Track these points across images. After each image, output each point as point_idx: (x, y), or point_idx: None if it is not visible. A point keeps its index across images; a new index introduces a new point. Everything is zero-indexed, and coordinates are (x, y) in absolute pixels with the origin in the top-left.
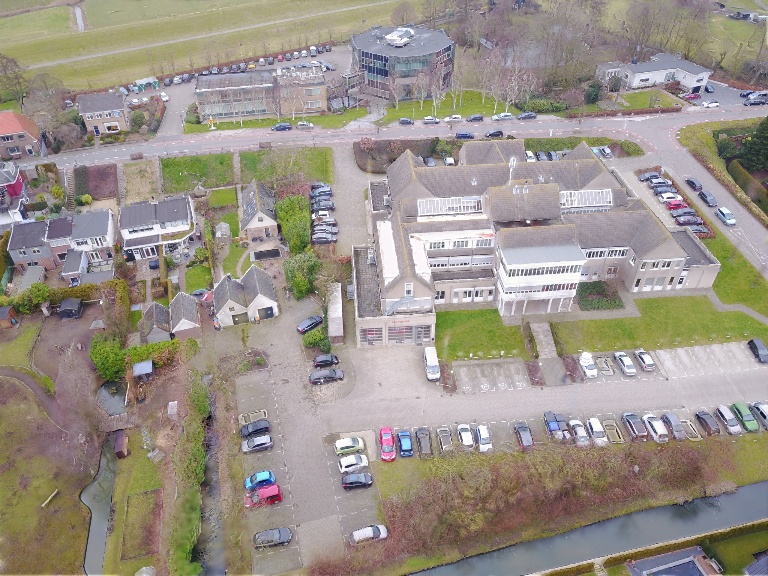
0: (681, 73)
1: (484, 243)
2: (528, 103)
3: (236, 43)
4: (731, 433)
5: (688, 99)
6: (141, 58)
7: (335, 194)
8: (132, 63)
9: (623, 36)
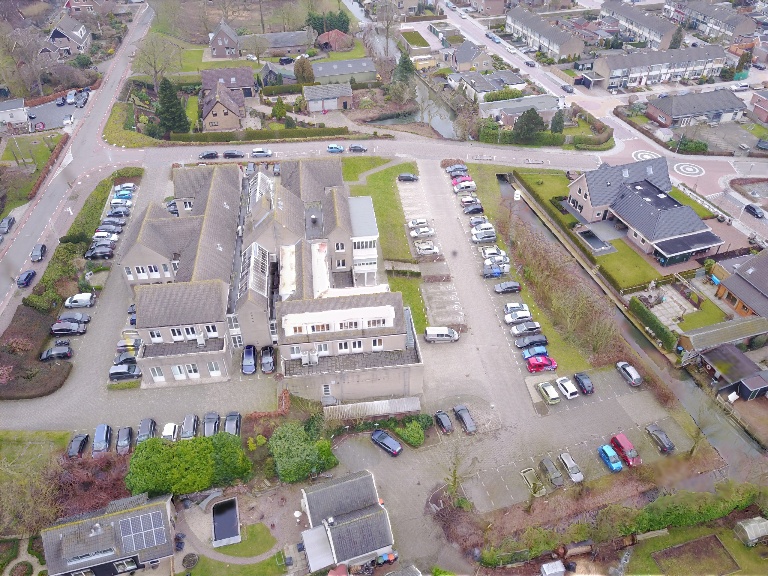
0: (4, 114)
1: None
2: None
3: None
4: (480, 203)
5: None
6: None
7: None
8: None
9: None
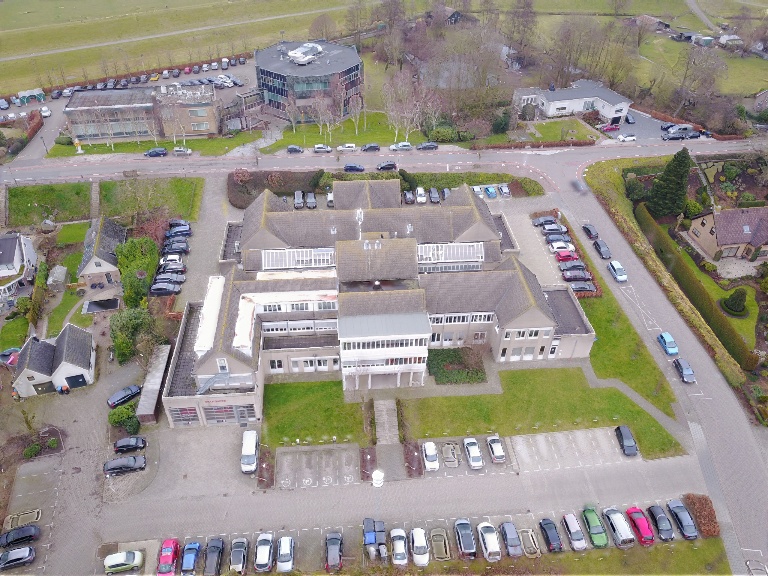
0: (600, 102)
1: (327, 306)
2: (432, 131)
3: (145, 52)
4: (574, 549)
5: (605, 131)
6: None
7: (195, 234)
8: (25, 71)
9: (557, 56)
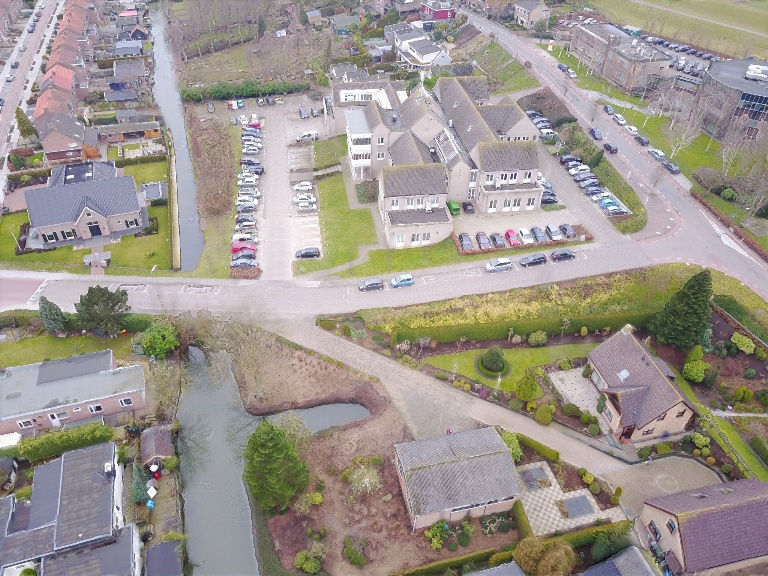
0: None
1: None
2: None
3: None
4: None
5: None
6: (683, 23)
7: None
8: (672, 23)
9: None
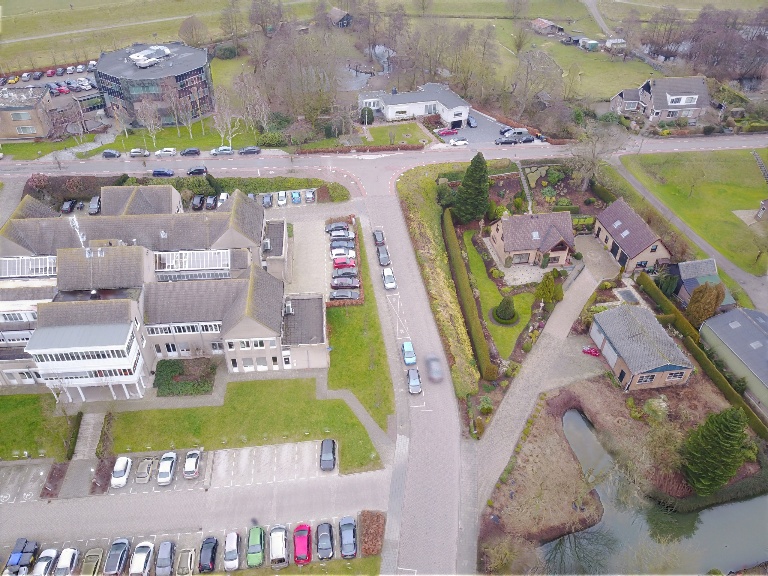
0: (440, 106)
1: None
2: None
3: (16, 54)
4: (225, 570)
5: (441, 135)
6: None
7: None
8: None
9: None
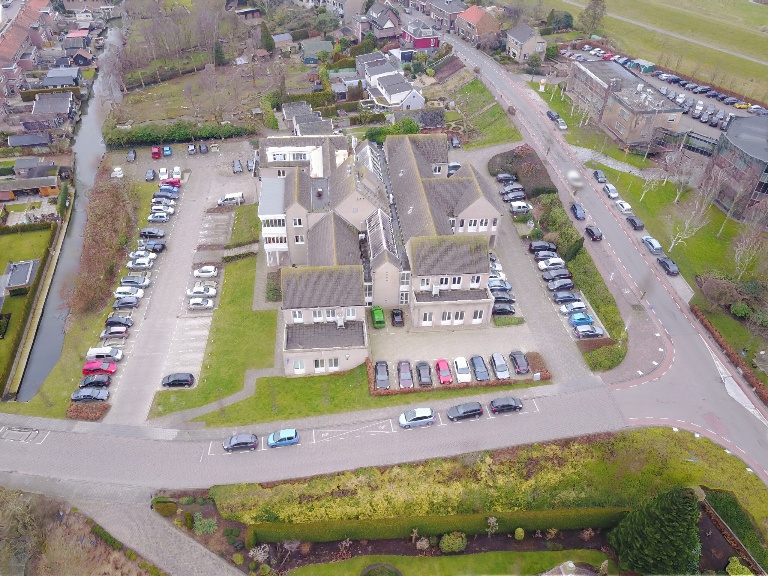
0: None
1: None
2: None
3: None
4: None
5: None
6: (705, 57)
7: None
8: (693, 56)
9: None
